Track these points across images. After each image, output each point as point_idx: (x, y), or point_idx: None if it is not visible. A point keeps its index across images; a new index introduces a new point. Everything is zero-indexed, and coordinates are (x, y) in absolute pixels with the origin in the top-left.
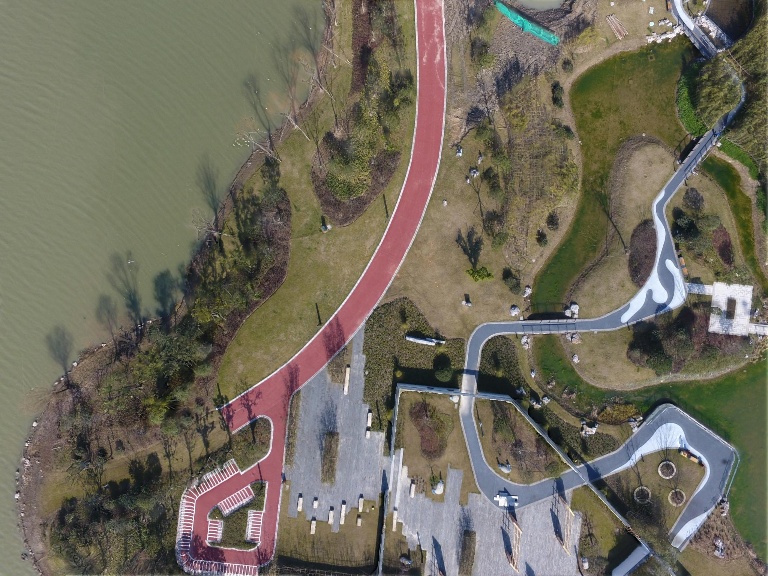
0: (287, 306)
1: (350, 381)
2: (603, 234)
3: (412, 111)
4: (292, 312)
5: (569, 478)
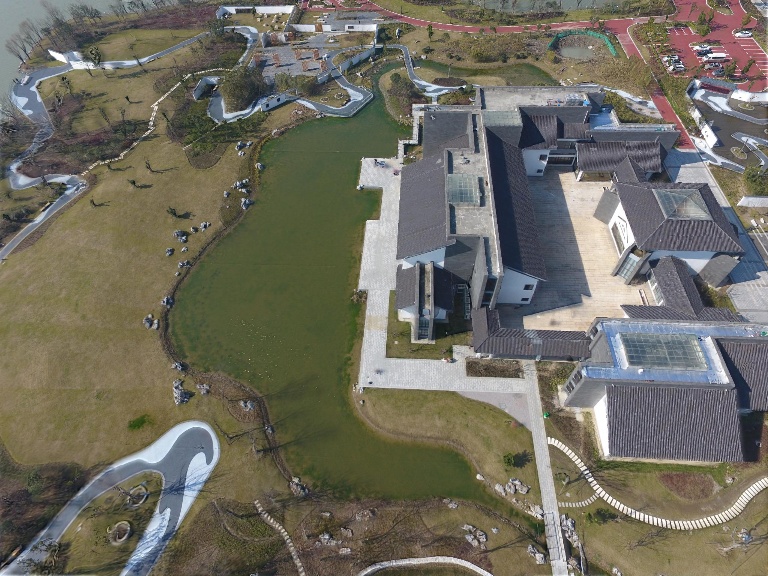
0: (408, 6)
1: (378, 21)
2: None
3: None
4: (406, 7)
5: (335, 71)
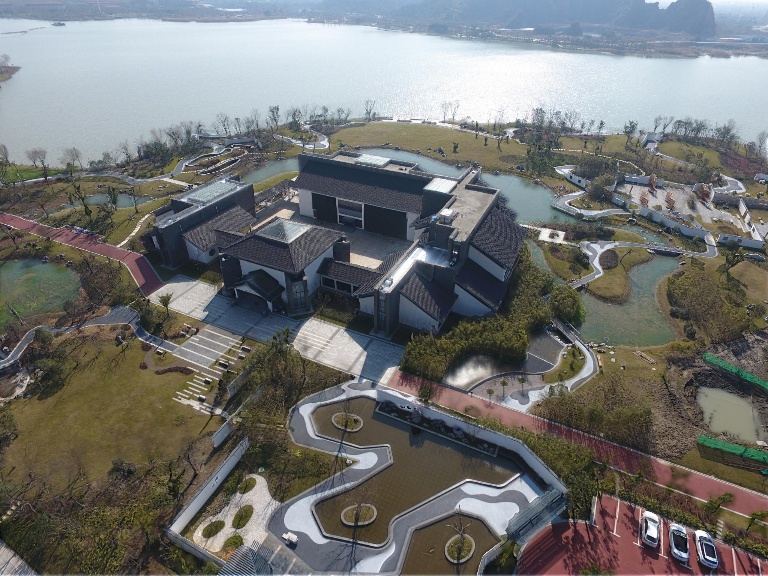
0: None
1: None
2: (633, 274)
3: None
4: None
5: None
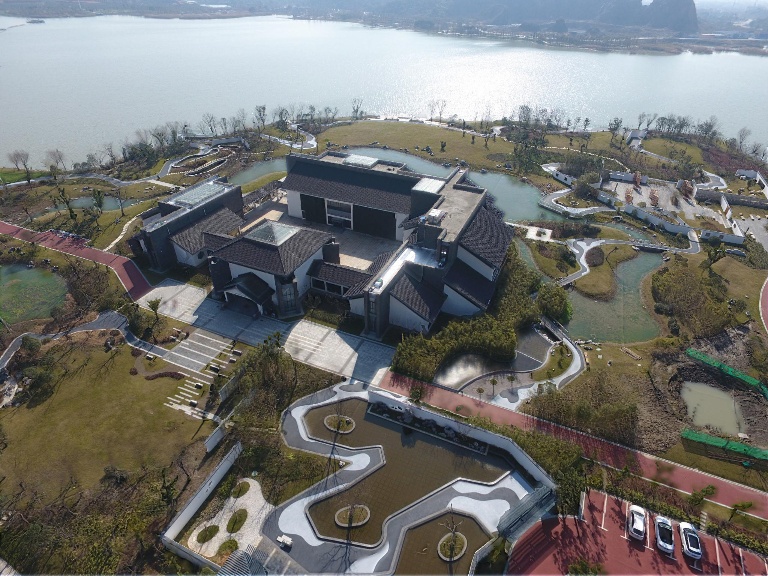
0: None
1: None
2: (619, 271)
3: None
4: None
5: None
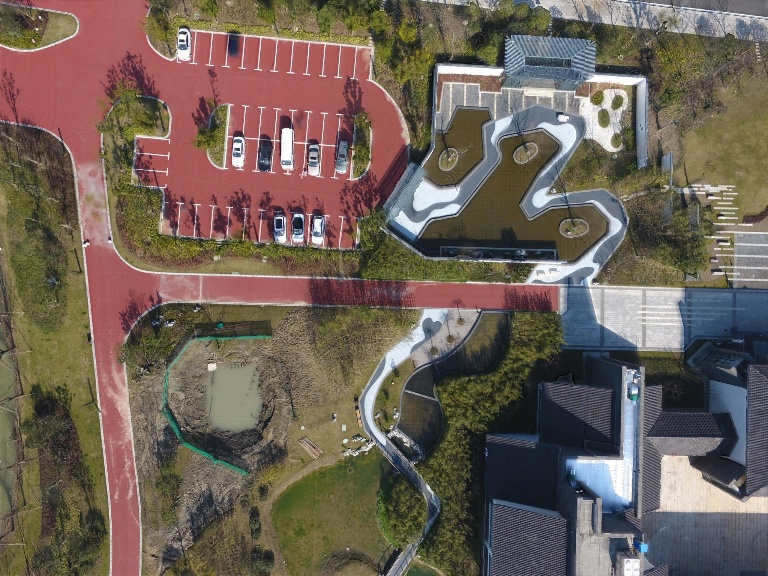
0: None
1: None
2: None
3: (106, 553)
4: None
5: None
